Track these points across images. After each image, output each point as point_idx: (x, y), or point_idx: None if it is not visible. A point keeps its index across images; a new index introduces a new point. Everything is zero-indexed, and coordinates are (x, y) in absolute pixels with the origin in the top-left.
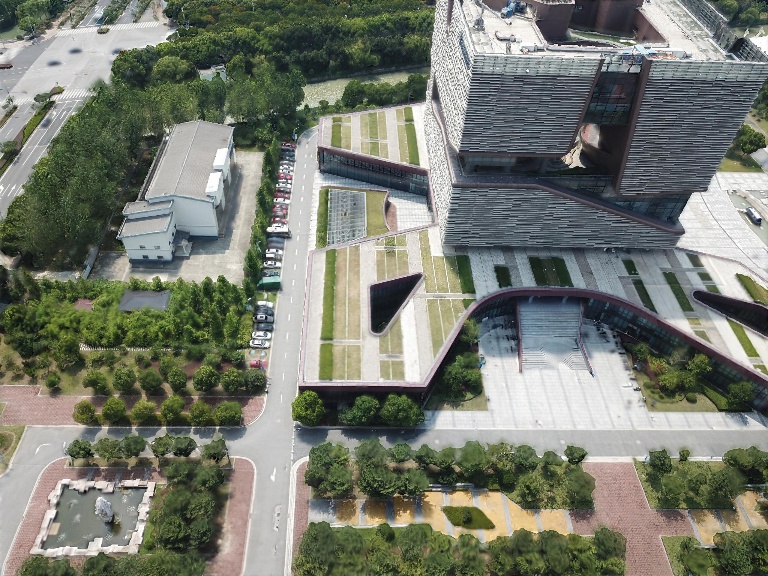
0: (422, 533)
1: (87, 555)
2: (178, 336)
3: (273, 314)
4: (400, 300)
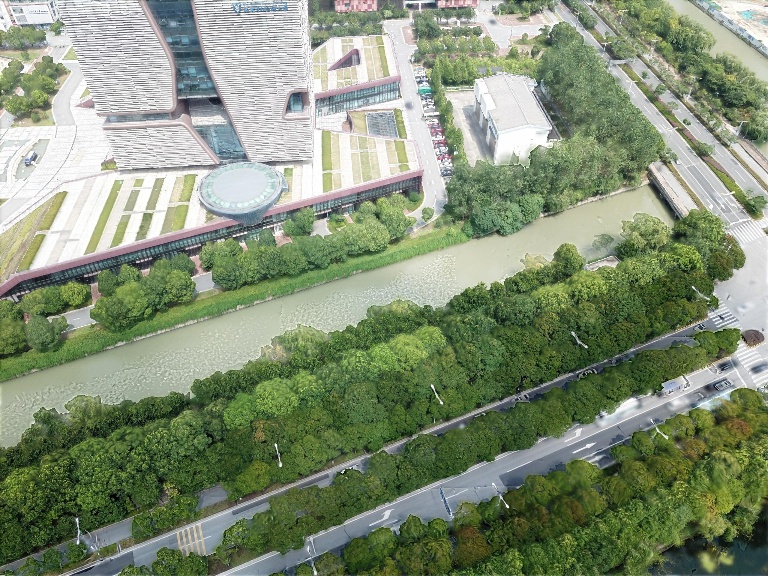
0: None
1: None
2: None
3: None
4: None
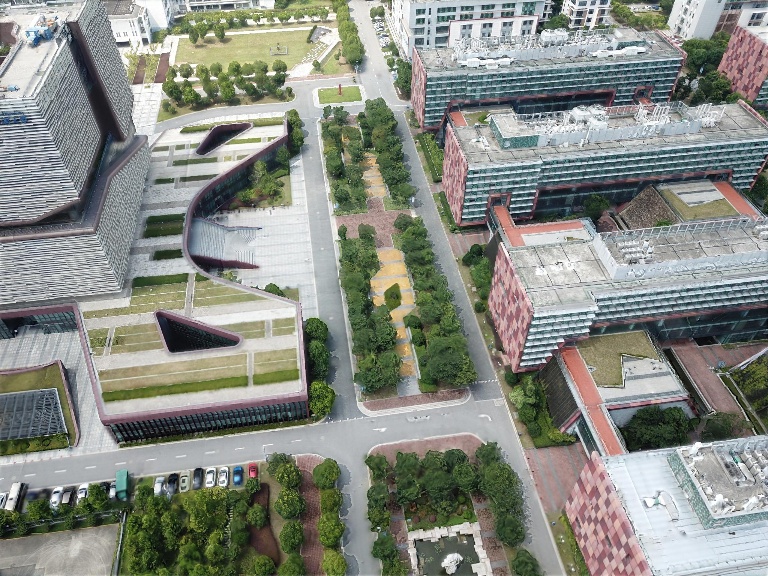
0: (415, 316)
1: (492, 570)
2: (217, 568)
3: (175, 474)
4: None
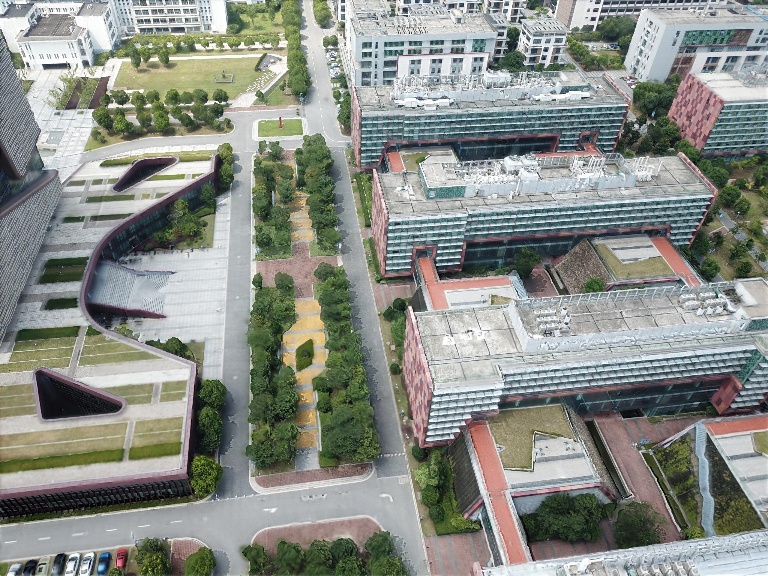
0: None
1: None
2: None
3: (34, 560)
4: (50, 412)
